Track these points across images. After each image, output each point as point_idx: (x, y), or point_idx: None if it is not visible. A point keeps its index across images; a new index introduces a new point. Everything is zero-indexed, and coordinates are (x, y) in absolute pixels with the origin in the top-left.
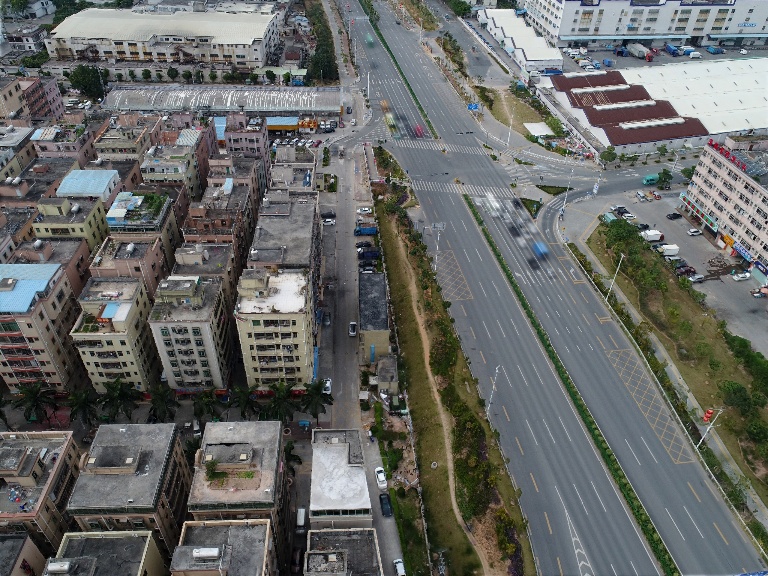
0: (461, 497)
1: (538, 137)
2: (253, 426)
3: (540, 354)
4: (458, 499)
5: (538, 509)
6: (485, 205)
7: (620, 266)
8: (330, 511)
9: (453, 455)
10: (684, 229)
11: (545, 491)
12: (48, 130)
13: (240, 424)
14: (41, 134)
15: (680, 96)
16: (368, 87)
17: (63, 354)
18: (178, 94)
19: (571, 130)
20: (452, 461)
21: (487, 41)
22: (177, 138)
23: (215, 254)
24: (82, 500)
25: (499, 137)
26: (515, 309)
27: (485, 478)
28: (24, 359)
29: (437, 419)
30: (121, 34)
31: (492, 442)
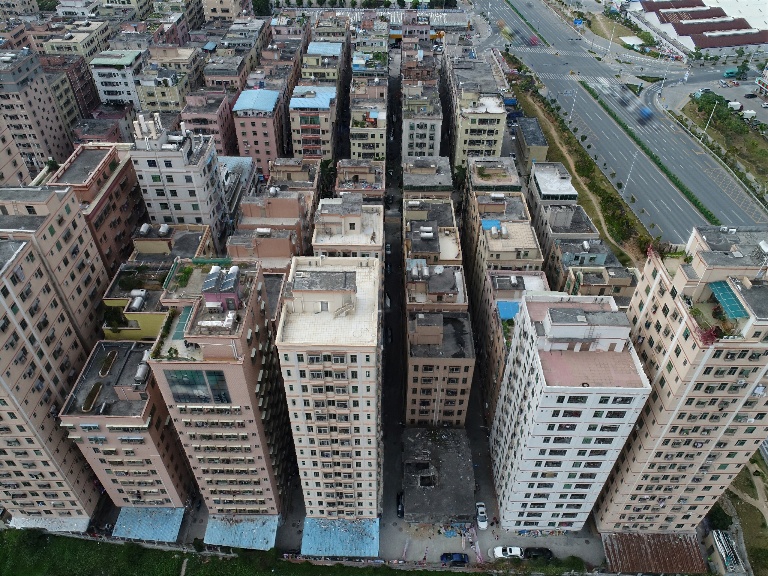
0: (612, 232)
1: (634, 45)
2: (496, 159)
3: (654, 169)
4: (610, 233)
5: (664, 239)
6: (597, 88)
7: (709, 123)
8: (553, 196)
9: (602, 213)
10: (759, 104)
11: (667, 232)
12: (281, 19)
13: (488, 158)
14: (277, 21)
15: (754, 16)
16: (489, 7)
17: (332, 151)
18: None
19: (660, 41)
20: (602, 216)
21: None
22: (373, 26)
23: (427, 91)
24: (411, 182)
25: (600, 46)
26: (632, 146)
27: (627, 223)
28: (314, 148)
29: (587, 198)
30: None
31: (627, 209)
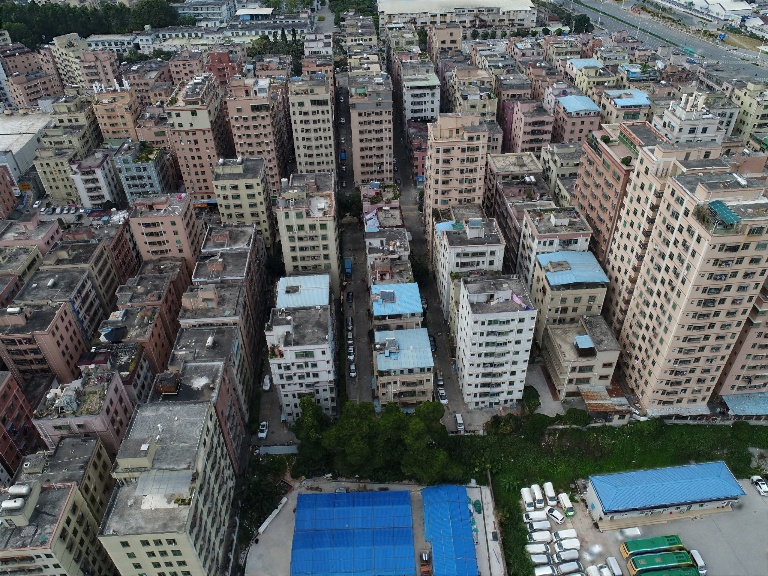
0: None
1: None
2: None
3: None
4: None
5: None
6: None
7: None
8: None
9: None
10: None
11: None
12: (524, 43)
13: None
14: (522, 46)
15: None
16: None
17: None
18: (504, 42)
19: None
20: None
21: (676, 4)
22: (602, 44)
23: None
24: None
25: None
26: None
27: None
28: None
29: None
30: (431, 9)
31: None
